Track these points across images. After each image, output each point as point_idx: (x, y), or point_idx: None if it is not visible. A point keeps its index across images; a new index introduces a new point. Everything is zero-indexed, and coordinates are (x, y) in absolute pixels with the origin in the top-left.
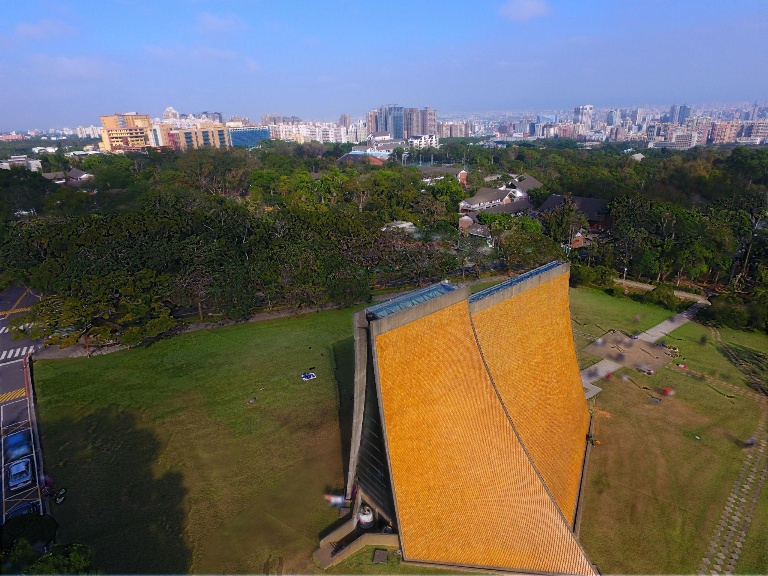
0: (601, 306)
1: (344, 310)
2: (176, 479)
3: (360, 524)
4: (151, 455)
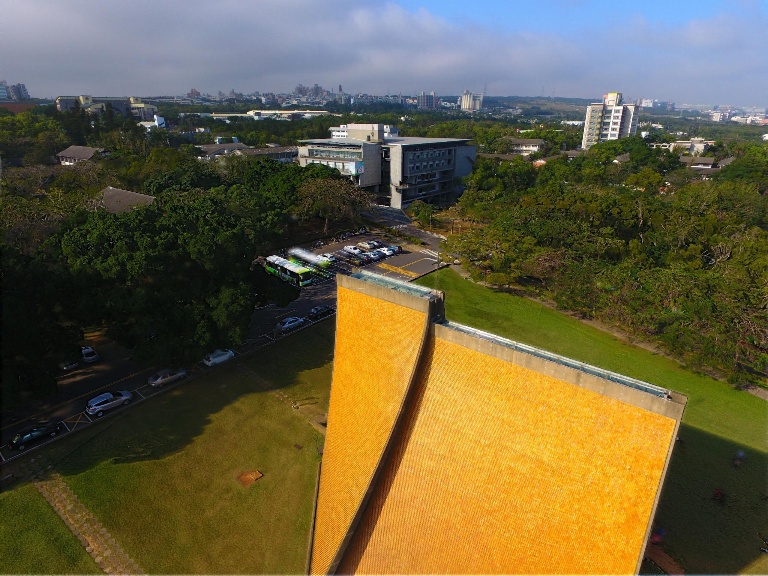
0: None
1: (684, 371)
2: None
3: None
4: None
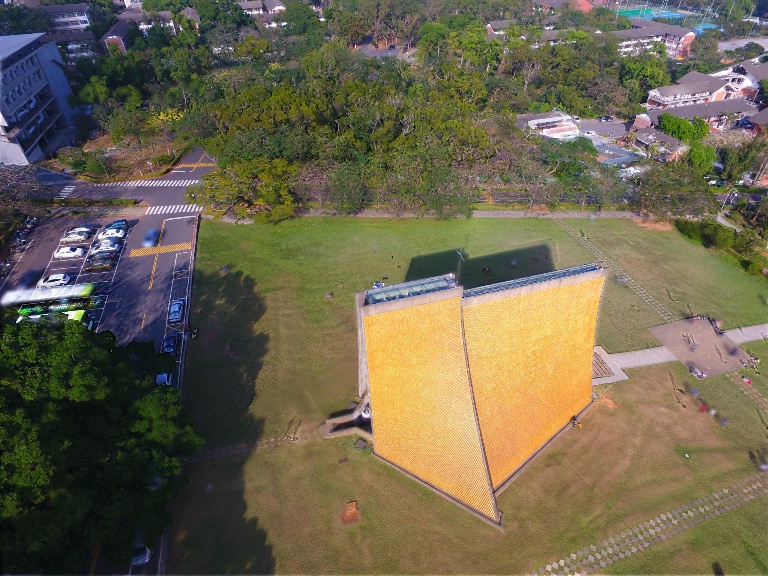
0: (717, 281)
1: (441, 222)
2: (260, 343)
3: (362, 417)
4: (251, 320)
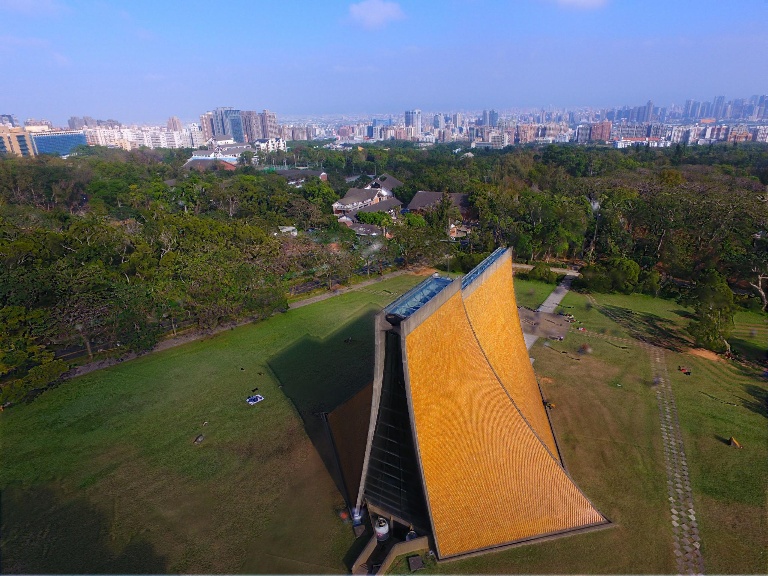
0: None
1: (261, 323)
2: (146, 550)
3: (377, 538)
4: (98, 531)
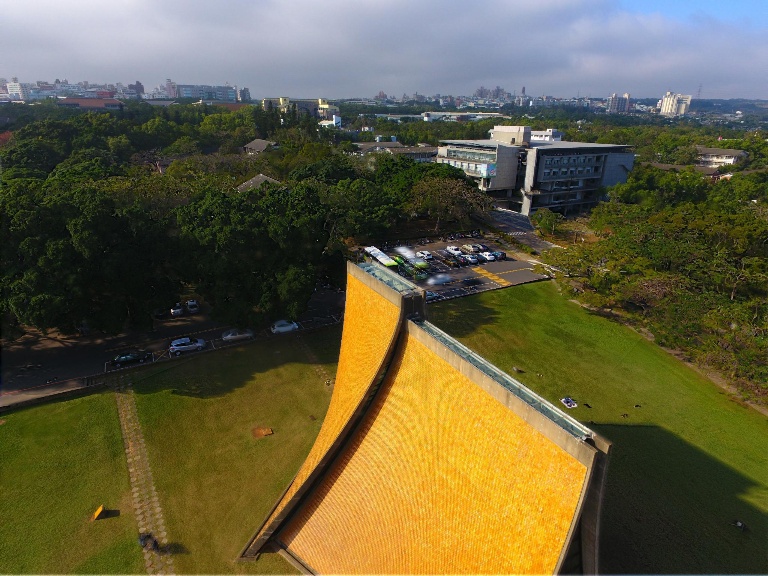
0: None
1: None
2: None
3: None
4: None
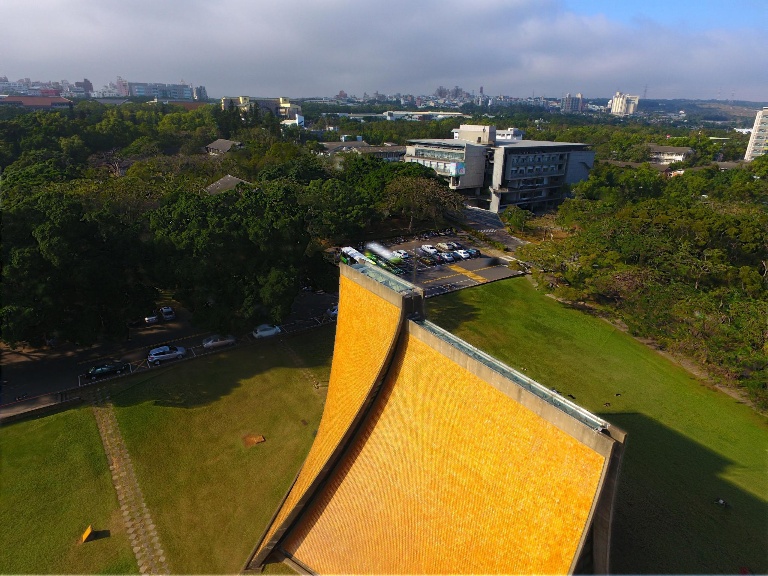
0: None
1: None
2: None
3: None
4: None
